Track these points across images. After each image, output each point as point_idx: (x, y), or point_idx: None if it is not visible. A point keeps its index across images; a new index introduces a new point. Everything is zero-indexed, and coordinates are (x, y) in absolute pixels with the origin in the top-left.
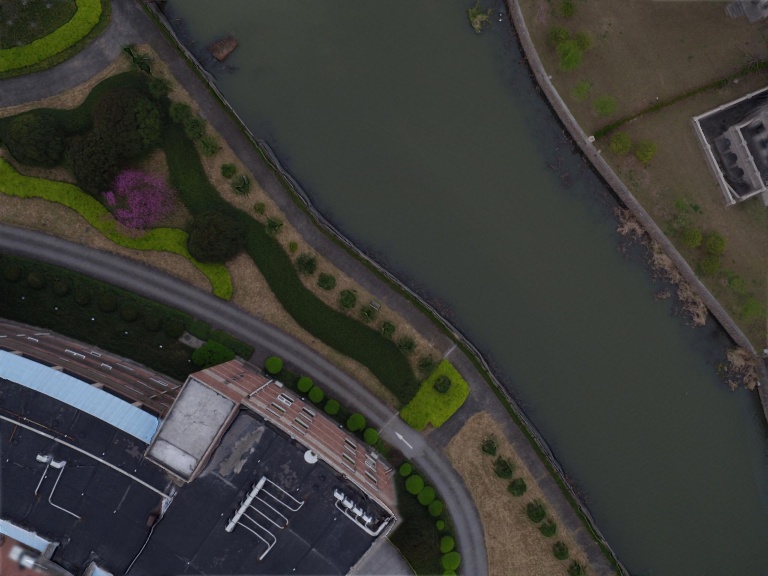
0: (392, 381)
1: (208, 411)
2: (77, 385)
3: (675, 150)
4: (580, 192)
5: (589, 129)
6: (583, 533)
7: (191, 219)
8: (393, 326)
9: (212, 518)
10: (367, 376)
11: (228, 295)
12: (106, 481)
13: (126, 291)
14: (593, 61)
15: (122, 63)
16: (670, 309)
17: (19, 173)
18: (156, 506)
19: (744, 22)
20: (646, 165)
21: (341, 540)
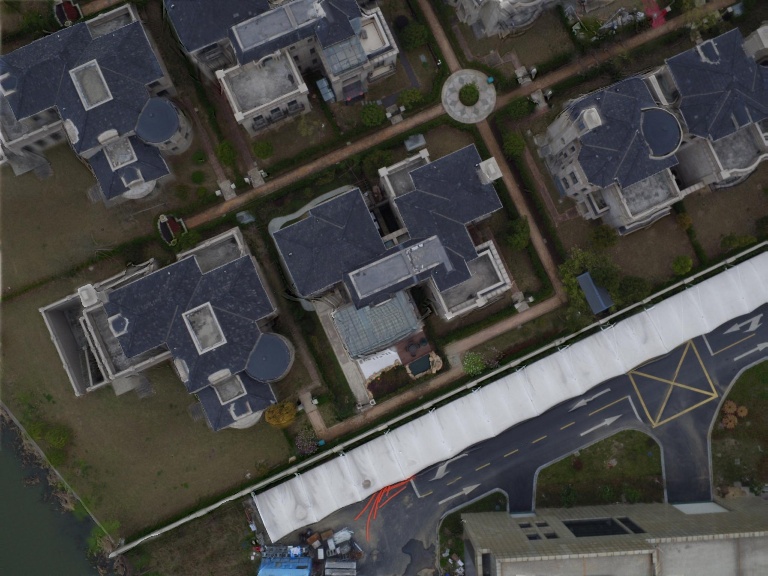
0: None
1: None
2: None
3: (28, 340)
4: None
5: None
6: None
7: None
8: None
9: None
10: None
11: None
12: None
13: None
14: None
15: None
16: (40, 494)
17: None
18: None
19: (101, 207)
20: None
21: None
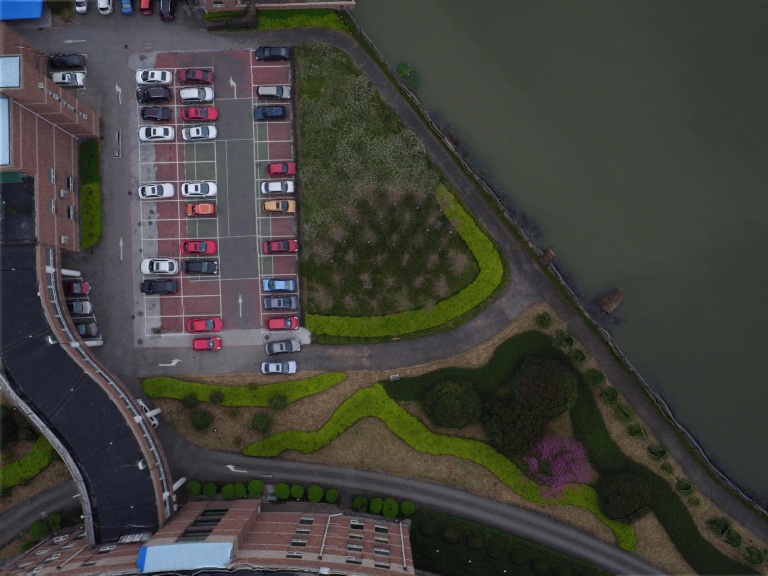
0: None
1: None
2: None
3: None
4: None
5: None
6: None
7: (594, 473)
8: None
9: None
10: None
11: (633, 548)
12: None
13: (534, 543)
14: None
15: (523, 322)
16: None
17: (431, 431)
18: None
19: None
20: None
21: None
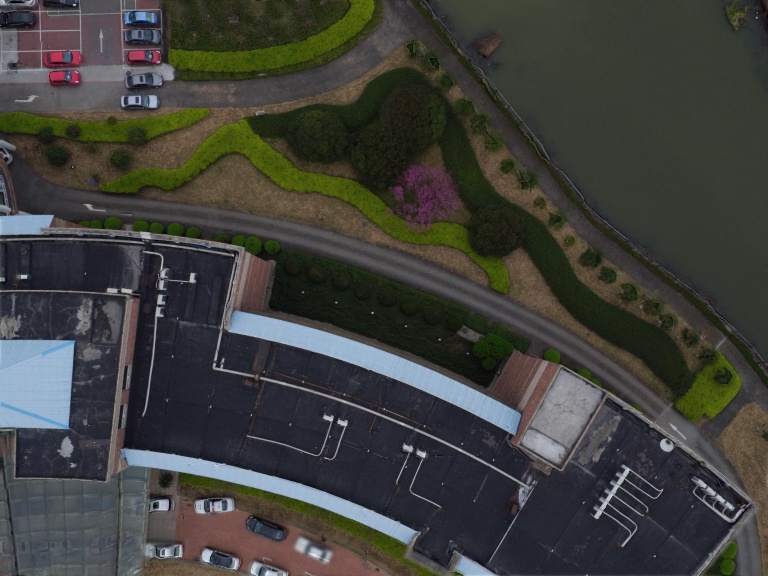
0: (669, 373)
1: (577, 400)
2: (433, 376)
3: None
4: None
5: None
6: None
7: (467, 214)
8: (672, 319)
9: (573, 506)
10: (641, 368)
11: (506, 289)
12: (464, 471)
13: (404, 285)
14: None
15: (395, 59)
16: None
17: (297, 168)
18: (513, 495)
19: None
20: None
21: (698, 527)
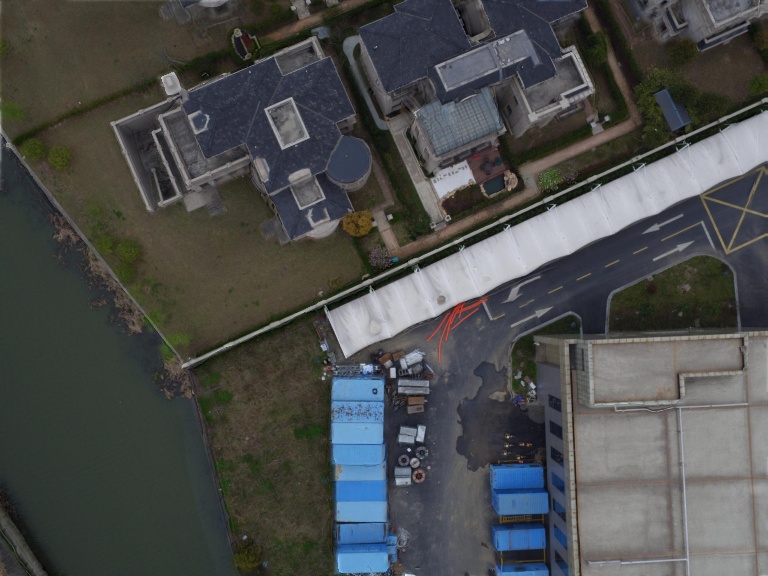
0: None
1: None
2: None
3: (98, 155)
4: (17, 198)
5: (14, 135)
6: (1, 543)
7: None
8: None
9: None
10: None
11: None
12: None
13: None
14: (18, 66)
15: None
16: (107, 316)
17: None
18: None
19: (174, 24)
20: (69, 171)
21: None
